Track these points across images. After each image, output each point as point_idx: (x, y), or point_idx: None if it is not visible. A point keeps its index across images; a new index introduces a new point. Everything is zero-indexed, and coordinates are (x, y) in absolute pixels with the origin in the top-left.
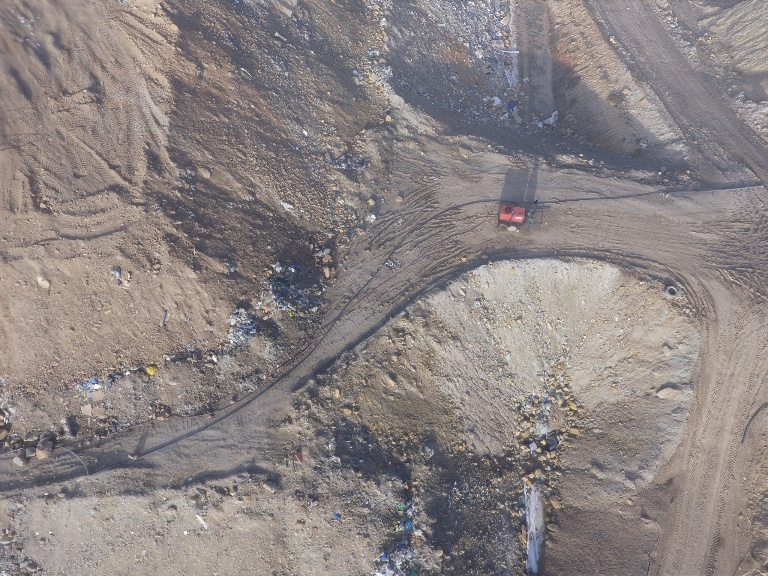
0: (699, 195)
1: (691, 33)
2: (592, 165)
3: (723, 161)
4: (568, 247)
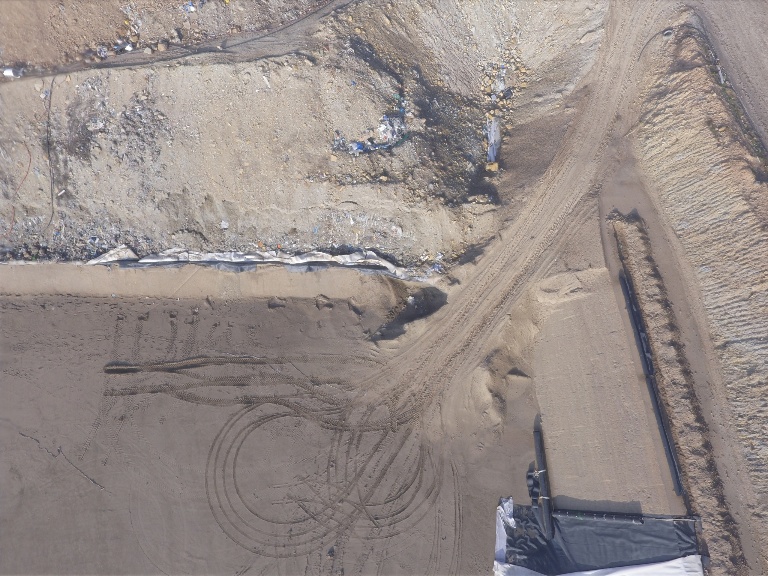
0: None
1: None
2: None
3: None
4: None
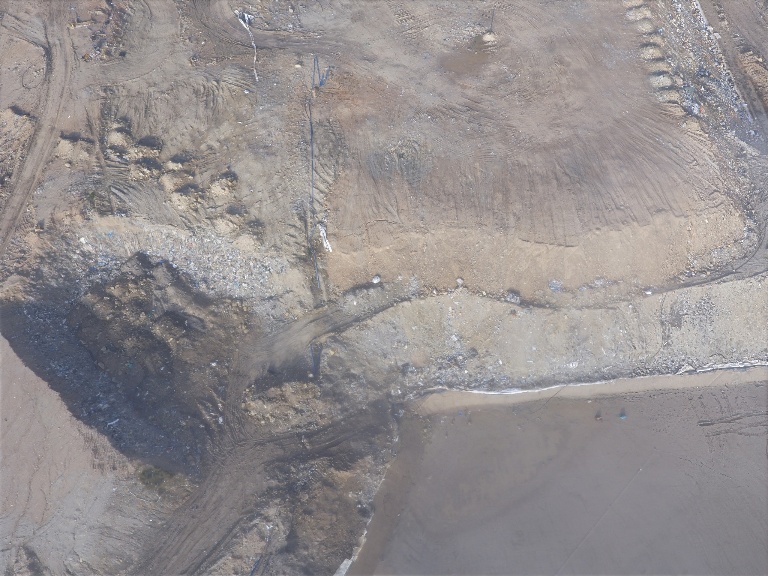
0: None
1: None
2: None
3: None
4: None
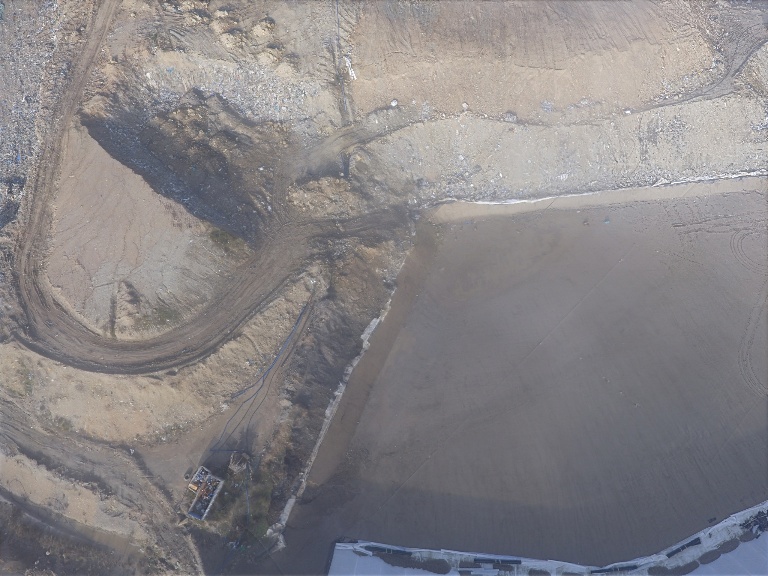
0: None
1: None
2: None
3: None
4: None
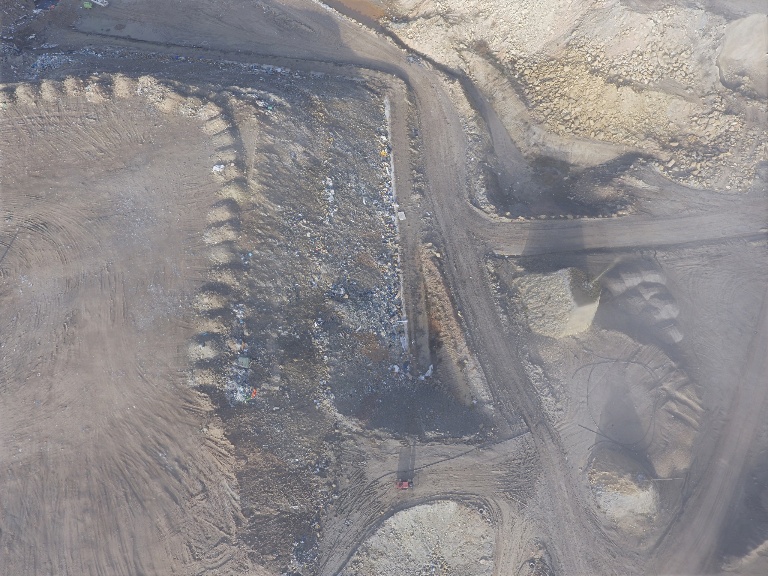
0: (497, 446)
1: (507, 294)
2: (443, 436)
3: (511, 416)
4: (432, 494)
